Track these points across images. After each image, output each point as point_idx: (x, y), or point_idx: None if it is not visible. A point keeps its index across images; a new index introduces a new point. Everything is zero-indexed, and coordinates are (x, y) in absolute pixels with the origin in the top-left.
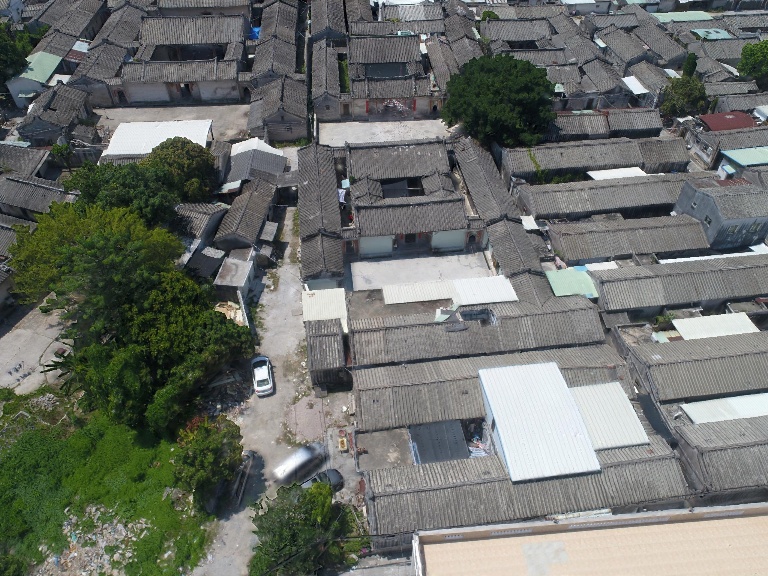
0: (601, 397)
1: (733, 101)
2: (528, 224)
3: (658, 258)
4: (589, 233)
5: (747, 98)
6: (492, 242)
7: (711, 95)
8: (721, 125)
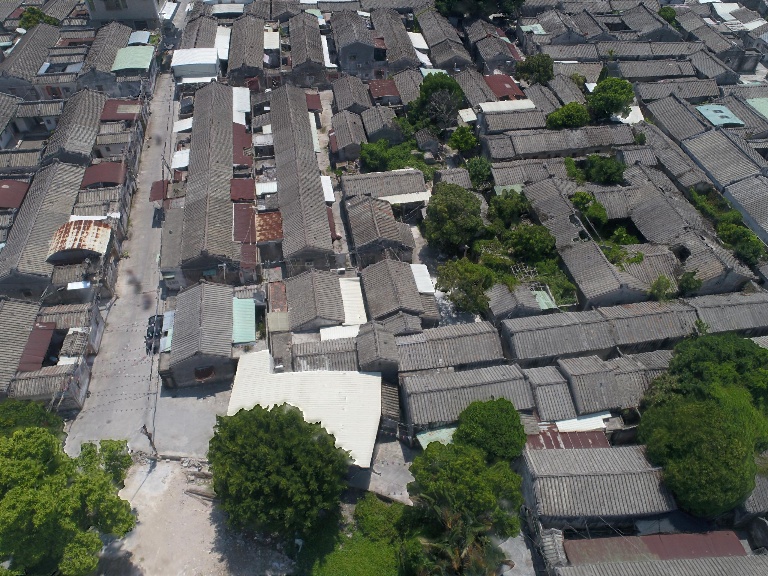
0: (236, 8)
1: (535, 89)
2: (363, 13)
3: None
4: None
5: (543, 96)
6: None
7: (554, 90)
8: (492, 80)
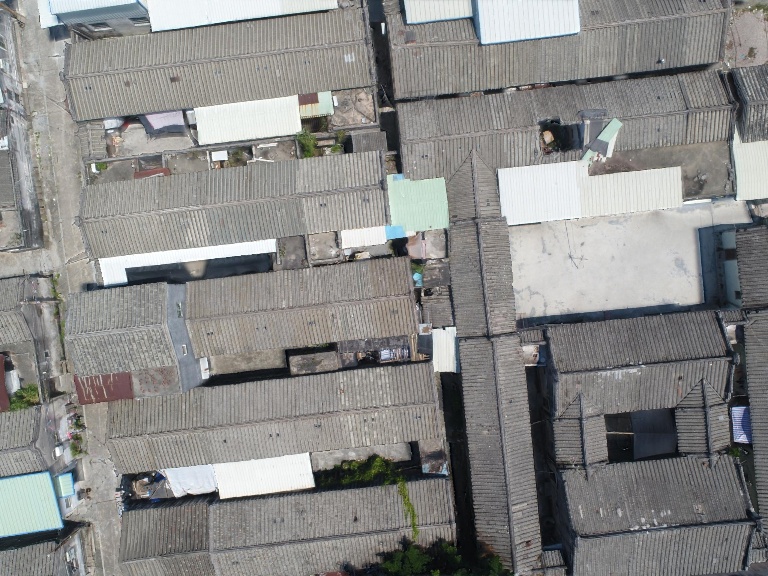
0: (436, 1)
1: None
2: (446, 344)
3: (272, 260)
4: (367, 299)
5: None
6: (513, 295)
7: None
8: None
